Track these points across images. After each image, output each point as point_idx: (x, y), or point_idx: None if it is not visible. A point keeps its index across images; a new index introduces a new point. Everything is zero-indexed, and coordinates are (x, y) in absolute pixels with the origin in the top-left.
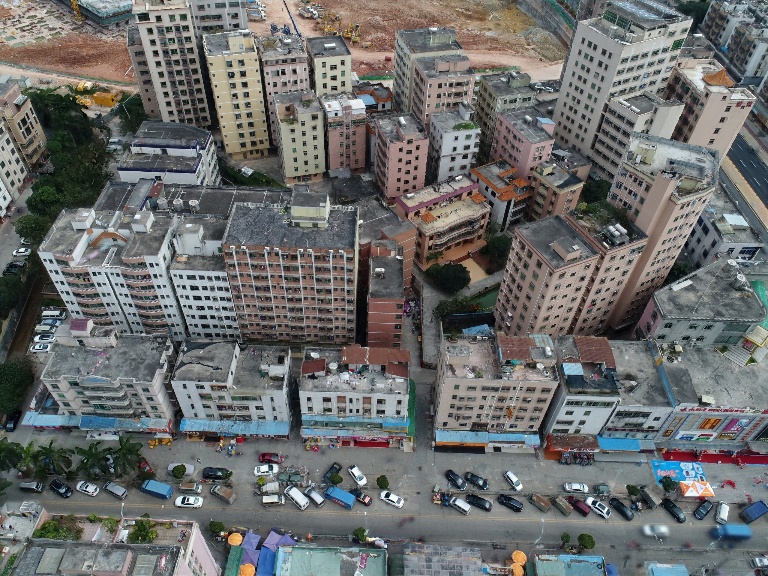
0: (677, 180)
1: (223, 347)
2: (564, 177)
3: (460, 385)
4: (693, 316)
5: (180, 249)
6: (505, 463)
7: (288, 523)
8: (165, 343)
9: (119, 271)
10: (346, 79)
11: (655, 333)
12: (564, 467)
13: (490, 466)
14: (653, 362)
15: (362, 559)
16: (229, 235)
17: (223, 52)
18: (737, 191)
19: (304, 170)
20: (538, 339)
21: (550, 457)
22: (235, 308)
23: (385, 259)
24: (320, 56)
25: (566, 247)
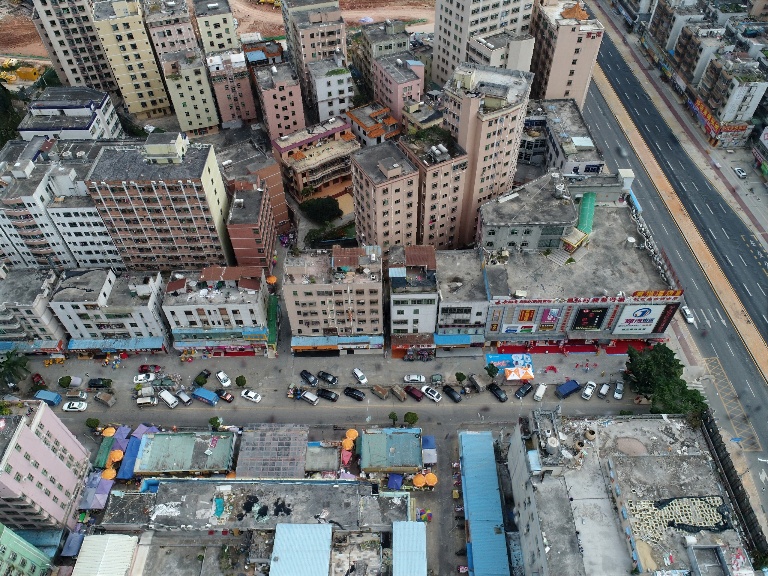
0: (478, 99)
1: (98, 273)
2: (429, 113)
3: (297, 291)
4: (511, 222)
5: (57, 191)
6: (356, 363)
7: (159, 419)
8: (48, 273)
9: (3, 213)
10: (231, 36)
11: (483, 241)
12: (408, 363)
13: (342, 366)
14: (481, 266)
15: (213, 440)
16: (94, 174)
17: (110, 17)
18: (616, 121)
19: (198, 123)
20: (369, 249)
21: (396, 356)
22: (114, 242)
23: (248, 192)
24: (203, 16)
25: (387, 166)
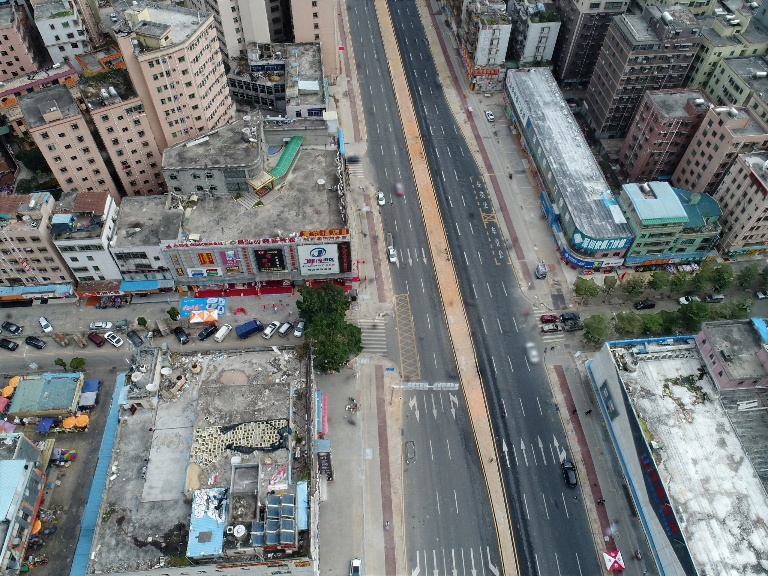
0: (128, 38)
1: None
2: None
3: None
4: (188, 166)
5: None
6: (46, 312)
7: None
8: None
9: None
10: None
11: (168, 186)
12: (100, 311)
13: (31, 316)
14: None
15: None
16: None
17: None
18: (387, 66)
19: None
20: (35, 196)
21: (90, 304)
22: None
23: None
24: None
25: (45, 109)
